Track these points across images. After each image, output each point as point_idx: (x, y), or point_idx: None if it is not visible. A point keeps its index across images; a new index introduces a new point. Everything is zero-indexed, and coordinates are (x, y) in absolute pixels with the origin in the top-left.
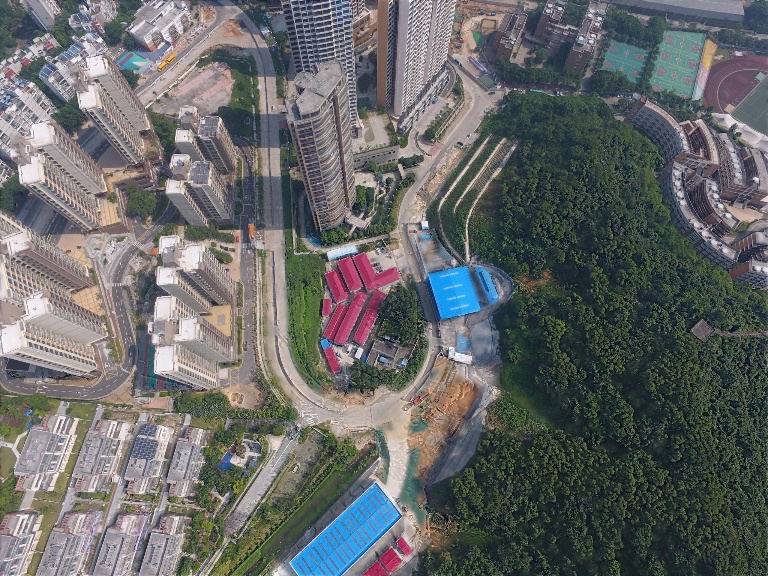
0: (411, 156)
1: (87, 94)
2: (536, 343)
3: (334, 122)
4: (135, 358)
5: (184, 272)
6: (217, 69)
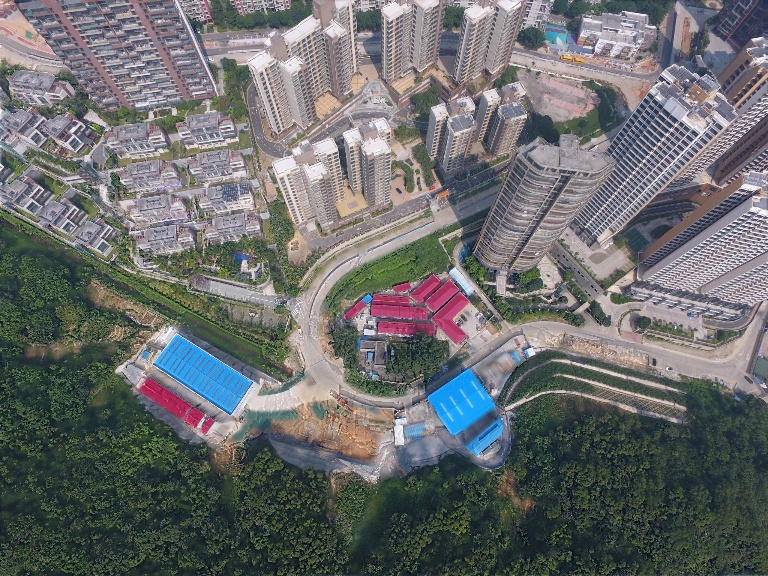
0: (607, 313)
1: (481, 9)
2: (433, 505)
3: (549, 193)
4: None
5: (361, 147)
6: (589, 97)
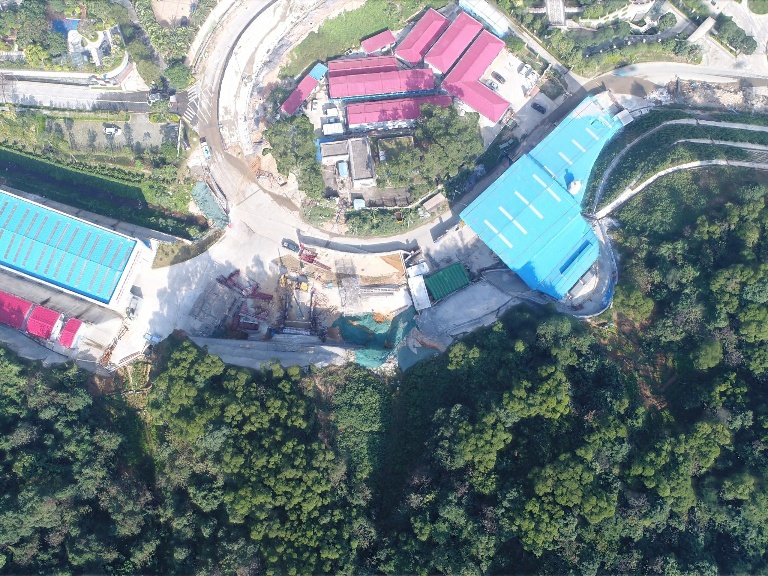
0: (745, 33)
1: None
2: (504, 382)
3: None
4: None
5: None
6: None
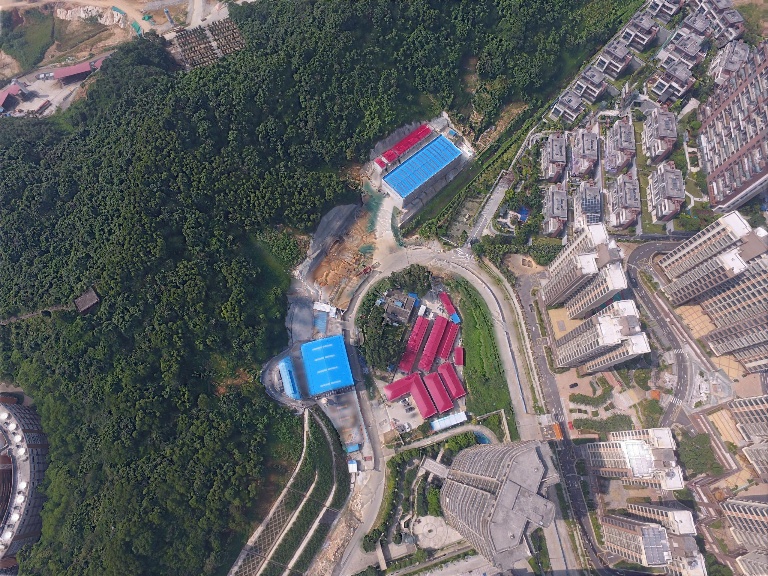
0: None
1: None
2: None
3: None
4: (628, 276)
5: None
6: None
